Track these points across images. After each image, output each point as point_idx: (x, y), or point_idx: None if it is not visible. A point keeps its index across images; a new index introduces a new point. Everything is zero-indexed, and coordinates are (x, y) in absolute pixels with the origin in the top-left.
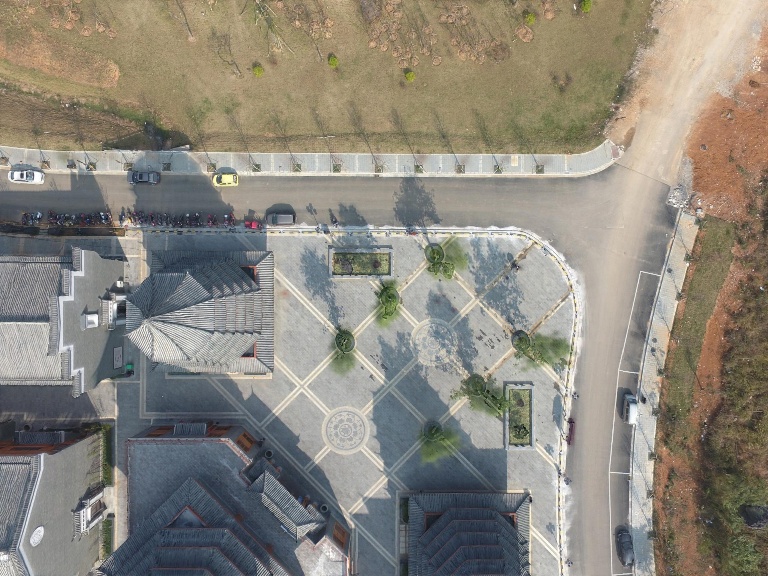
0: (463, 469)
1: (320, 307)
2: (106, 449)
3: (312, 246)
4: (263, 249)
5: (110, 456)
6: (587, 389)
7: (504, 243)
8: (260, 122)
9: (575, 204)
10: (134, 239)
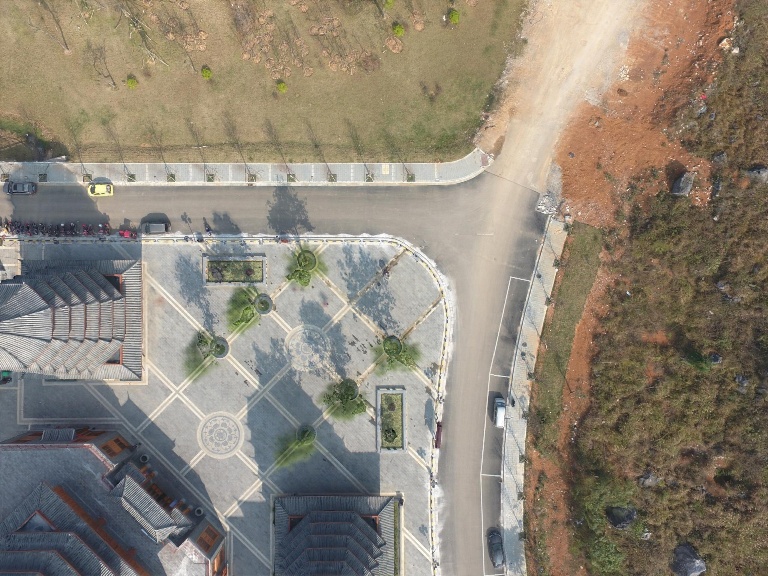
0: (336, 472)
1: (195, 314)
2: None
3: (187, 254)
4: (138, 257)
5: None
6: (458, 393)
7: (376, 250)
8: (136, 133)
9: (446, 211)
10: (11, 248)
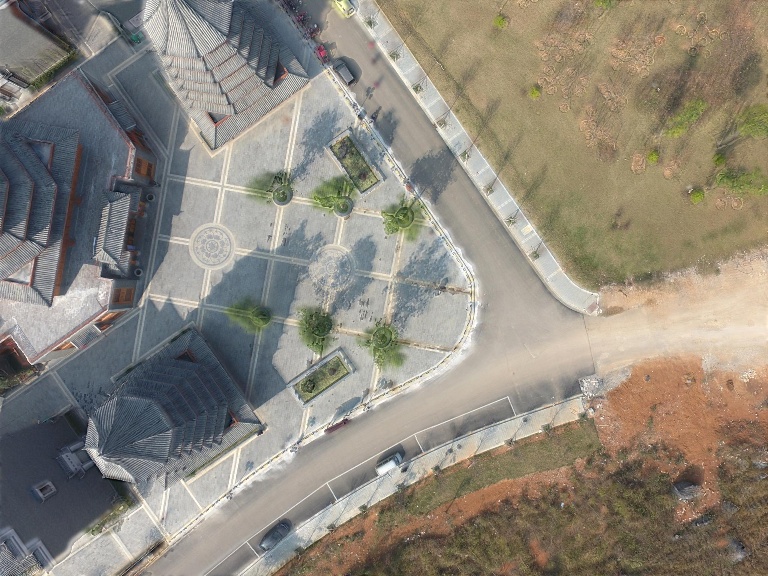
0: (247, 363)
1: (296, 156)
2: (64, 64)
3: (341, 114)
4: (311, 76)
5: (61, 71)
6: (381, 419)
7: (453, 269)
8: (413, 0)
9: (526, 305)
10: None
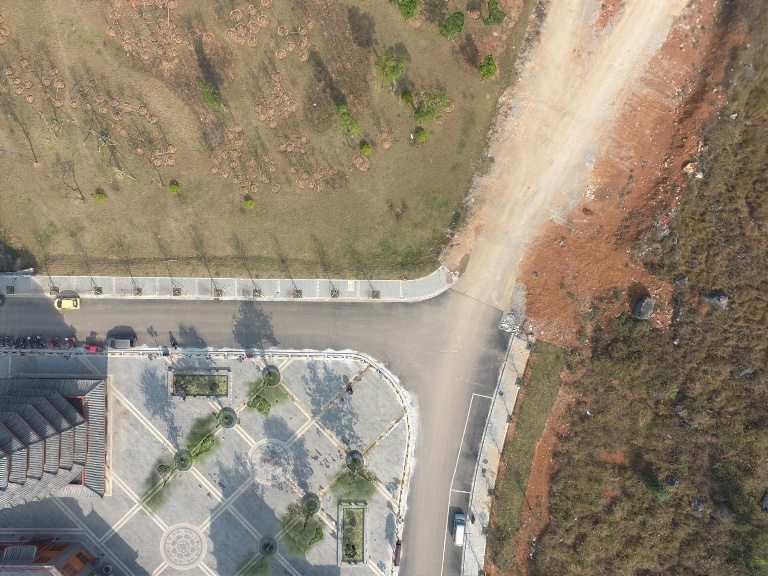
0: None
1: (159, 427)
2: None
3: (152, 367)
4: (104, 370)
5: None
6: (419, 508)
7: (340, 366)
8: (104, 245)
9: (410, 328)
10: None
